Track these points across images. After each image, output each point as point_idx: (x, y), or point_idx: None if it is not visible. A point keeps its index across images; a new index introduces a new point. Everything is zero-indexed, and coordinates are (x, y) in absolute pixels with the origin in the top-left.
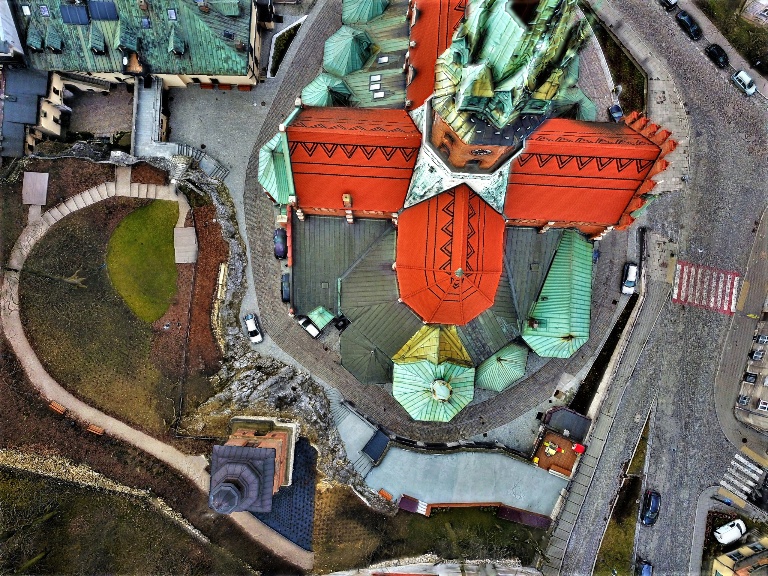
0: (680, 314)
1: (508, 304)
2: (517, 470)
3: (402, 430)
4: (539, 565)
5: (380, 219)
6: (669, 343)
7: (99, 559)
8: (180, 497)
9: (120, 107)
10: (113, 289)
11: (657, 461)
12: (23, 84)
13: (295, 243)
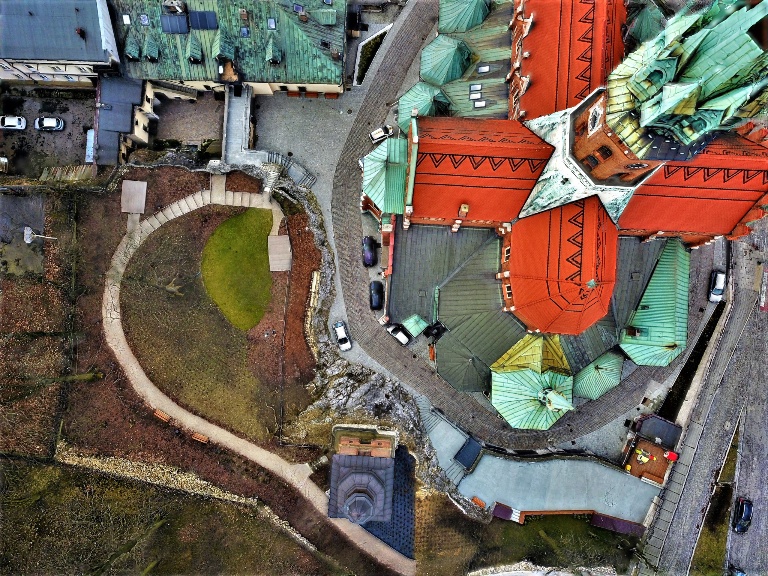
0: (767, 322)
1: (608, 313)
2: (609, 478)
3: (490, 437)
4: (635, 573)
5: (483, 228)
6: (757, 351)
7: (211, 567)
8: (286, 505)
9: (207, 115)
10: (208, 297)
11: (747, 469)
12: (118, 92)
13: (396, 252)
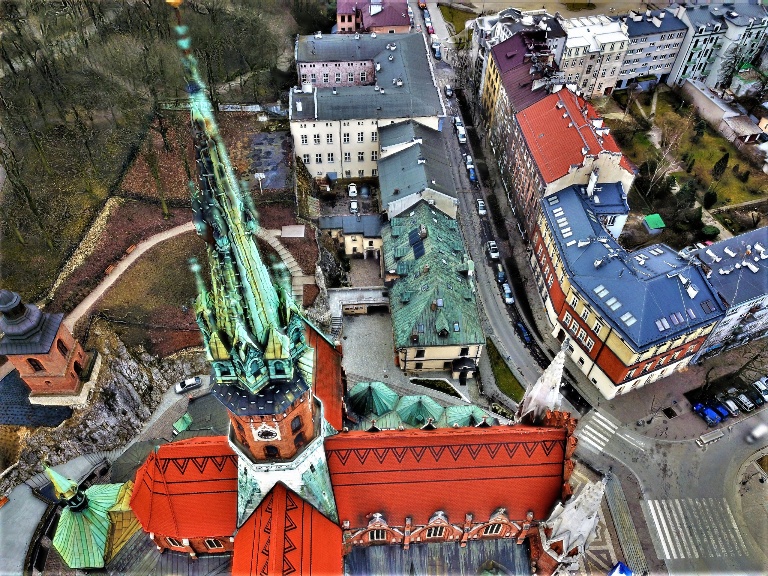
0: None
1: None
2: None
3: None
4: None
5: None
6: None
7: (8, 270)
8: None
9: (371, 285)
10: None
11: None
12: (370, 224)
13: None
